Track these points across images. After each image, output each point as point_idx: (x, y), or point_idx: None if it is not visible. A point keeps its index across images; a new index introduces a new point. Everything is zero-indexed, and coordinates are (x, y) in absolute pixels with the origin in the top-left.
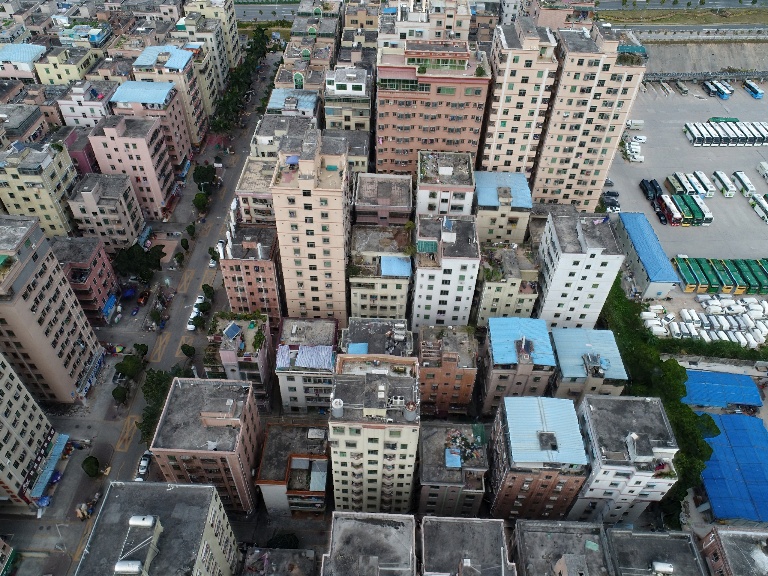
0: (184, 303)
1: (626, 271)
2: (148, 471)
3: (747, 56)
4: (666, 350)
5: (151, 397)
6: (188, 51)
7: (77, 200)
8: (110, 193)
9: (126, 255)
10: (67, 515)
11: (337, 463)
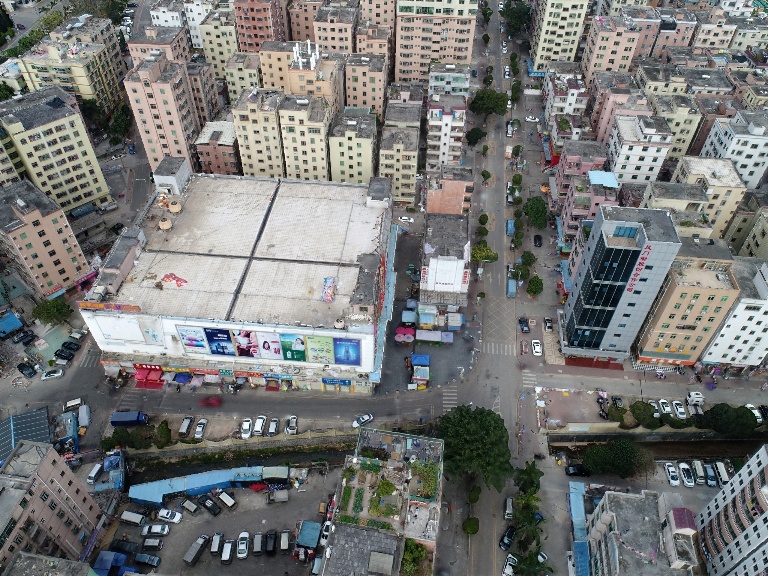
0: (492, 5)
1: None
2: (507, 46)
3: None
4: None
5: (506, 16)
6: None
7: None
8: None
9: None
10: (479, 55)
11: (616, 1)
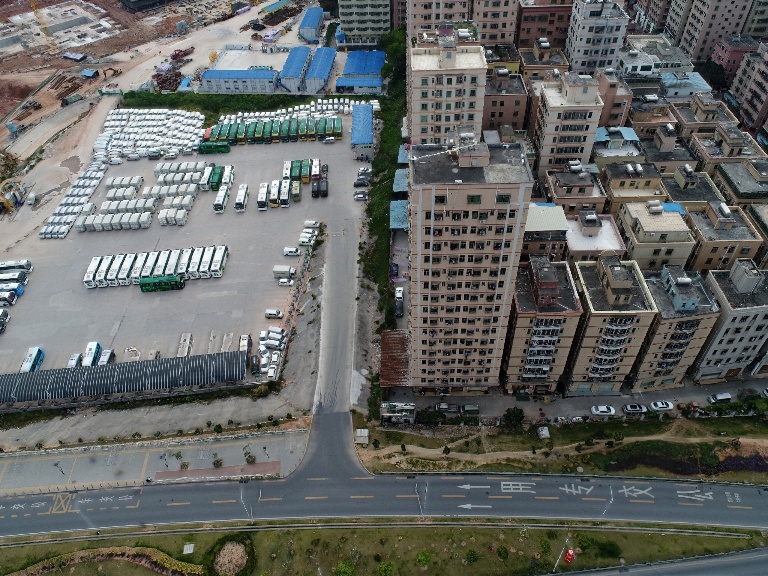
0: None
1: (377, 132)
2: None
3: None
4: (374, 96)
5: None
6: None
7: None
8: (759, 59)
9: (718, 67)
10: None
11: None
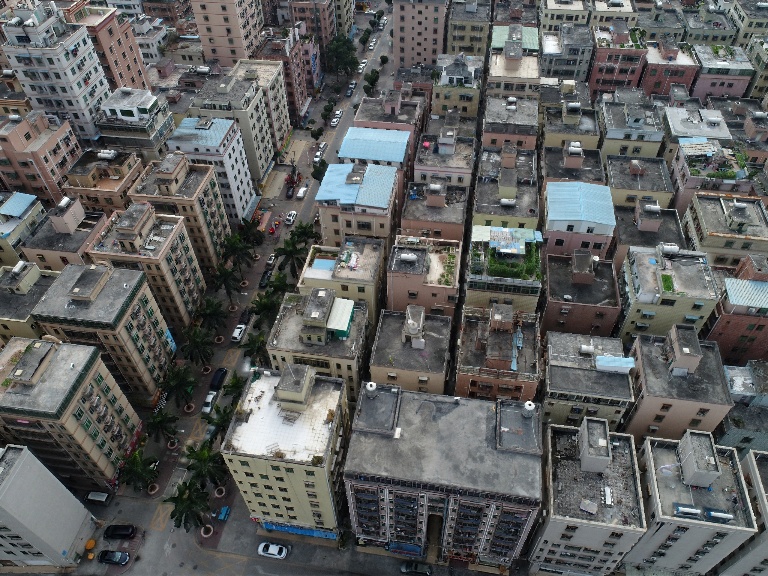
0: (347, 125)
1: None
2: None
3: None
4: None
5: None
6: (322, 198)
7: (421, 97)
8: None
9: None
10: None
11: None
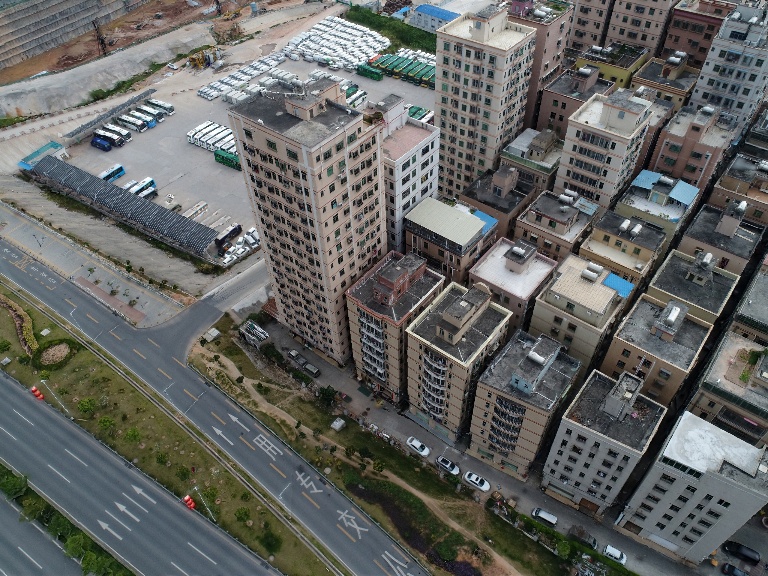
0: None
1: None
2: None
3: (22, 198)
4: None
5: None
6: None
7: None
8: None
9: None
10: None
11: None
